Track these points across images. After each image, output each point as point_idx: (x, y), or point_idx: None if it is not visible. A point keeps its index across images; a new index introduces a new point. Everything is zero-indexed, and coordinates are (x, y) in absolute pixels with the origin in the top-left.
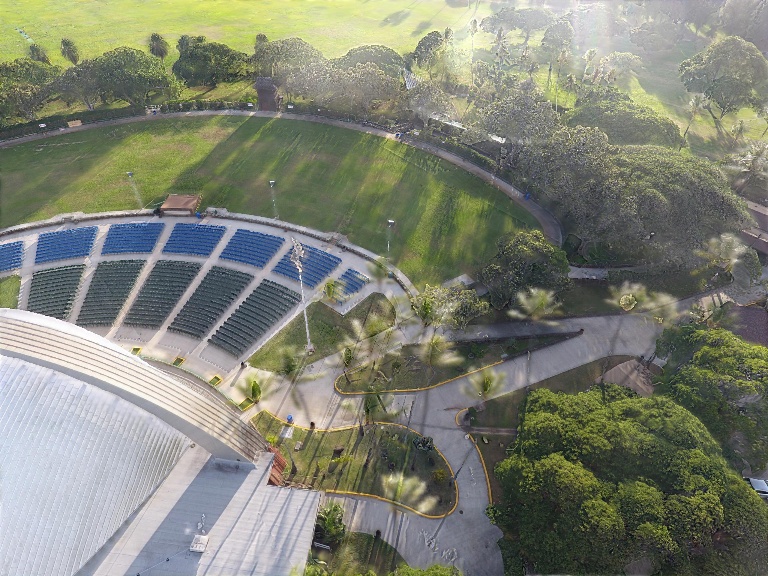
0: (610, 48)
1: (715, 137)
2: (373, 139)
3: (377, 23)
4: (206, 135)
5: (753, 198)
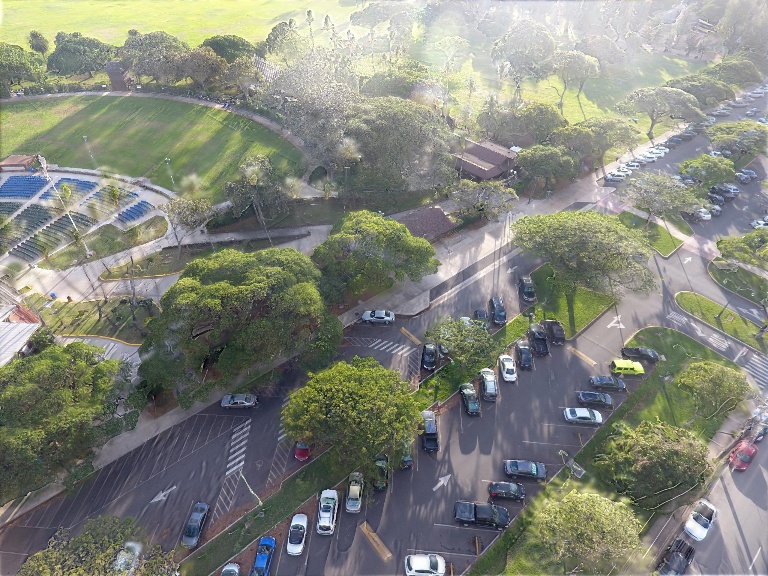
0: (464, 36)
1: (508, 101)
2: (202, 109)
3: (265, 21)
4: (58, 111)
5: (505, 142)
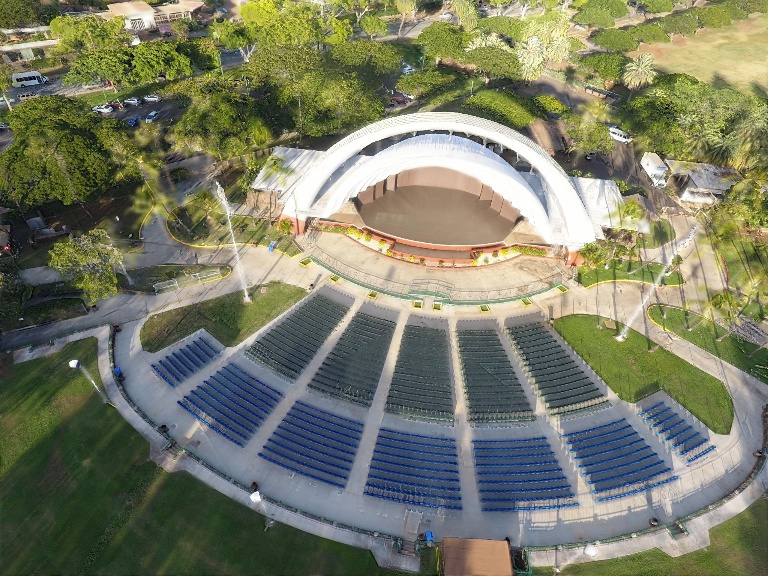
0: None
1: None
2: None
3: None
4: None
5: None
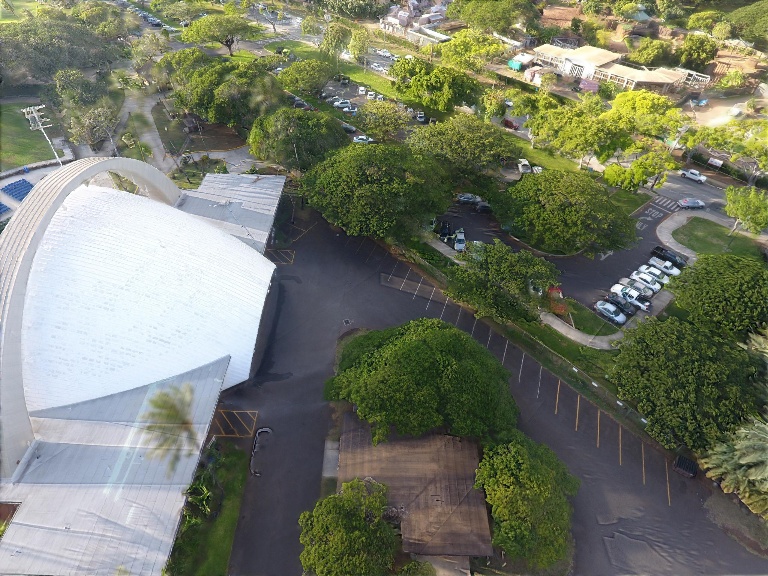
0: None
1: None
2: None
3: None
4: None
5: None
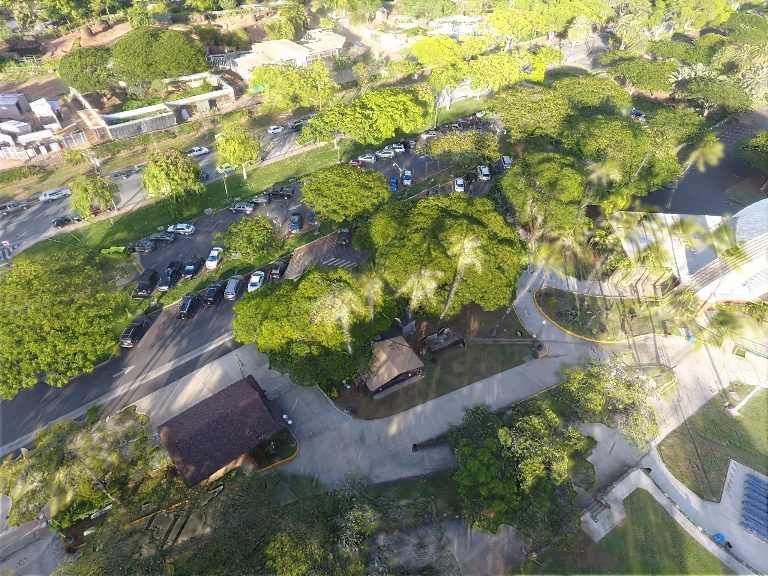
0: None
1: None
2: None
3: None
4: None
5: None
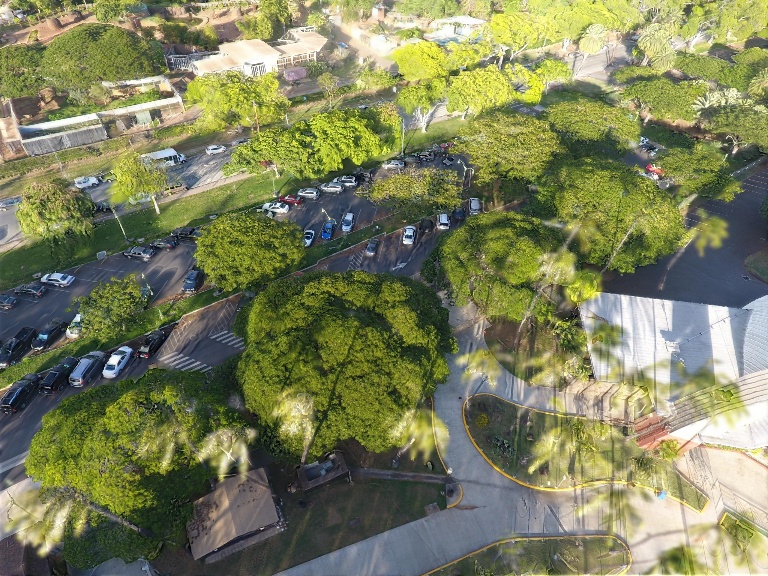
0: None
1: None
2: None
3: None
4: None
5: None
